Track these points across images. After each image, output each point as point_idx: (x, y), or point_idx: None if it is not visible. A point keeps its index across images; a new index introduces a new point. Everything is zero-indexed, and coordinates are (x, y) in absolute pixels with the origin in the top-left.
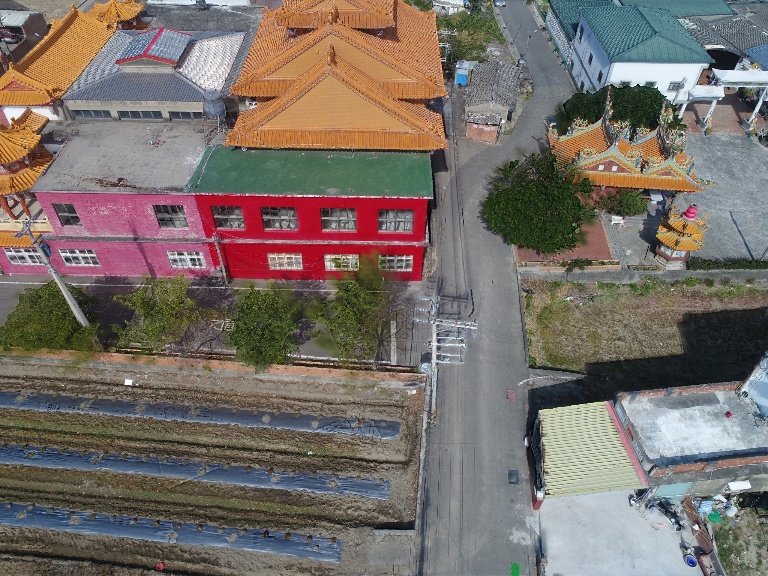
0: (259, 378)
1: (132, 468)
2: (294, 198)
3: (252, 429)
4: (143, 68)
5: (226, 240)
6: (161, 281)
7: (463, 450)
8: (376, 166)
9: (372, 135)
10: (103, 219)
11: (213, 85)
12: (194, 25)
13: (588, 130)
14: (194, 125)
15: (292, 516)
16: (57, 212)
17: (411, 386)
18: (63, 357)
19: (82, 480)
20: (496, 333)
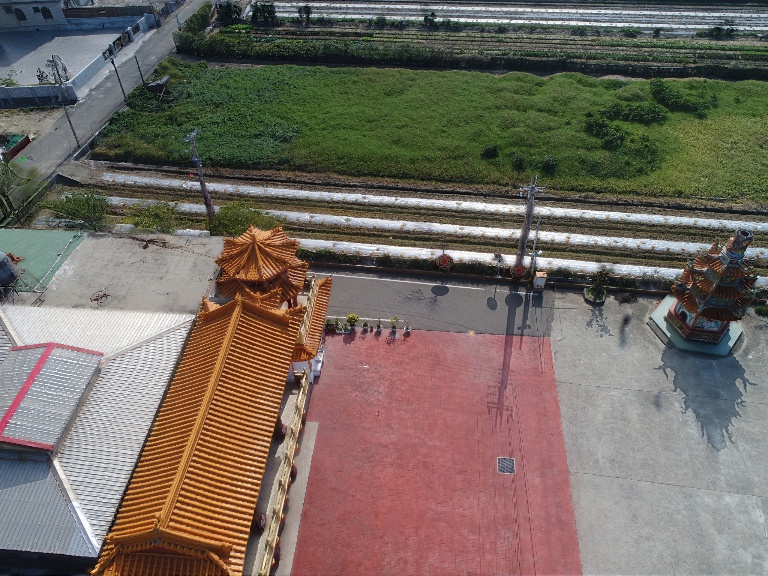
0: None
1: (205, 207)
2: None
3: None
4: None
5: None
6: None
7: None
8: None
9: None
10: None
11: None
12: None
13: None
14: None
15: (120, 189)
16: None
17: None
18: None
19: (234, 204)
20: None
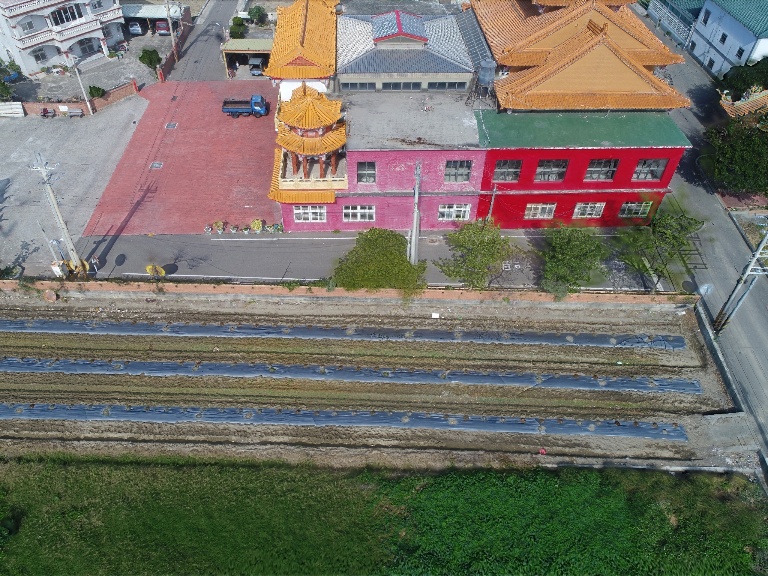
0: (549, 307)
1: (478, 380)
2: (573, 150)
3: (562, 347)
4: (397, 45)
5: (498, 192)
6: (471, 224)
7: (754, 352)
8: (629, 123)
9: (623, 97)
10: (397, 175)
11: (463, 59)
12: (384, 12)
13: (762, 95)
14: (449, 94)
15: (631, 410)
16: (357, 170)
17: (680, 308)
18: (377, 296)
19: (440, 391)
20: (736, 263)
